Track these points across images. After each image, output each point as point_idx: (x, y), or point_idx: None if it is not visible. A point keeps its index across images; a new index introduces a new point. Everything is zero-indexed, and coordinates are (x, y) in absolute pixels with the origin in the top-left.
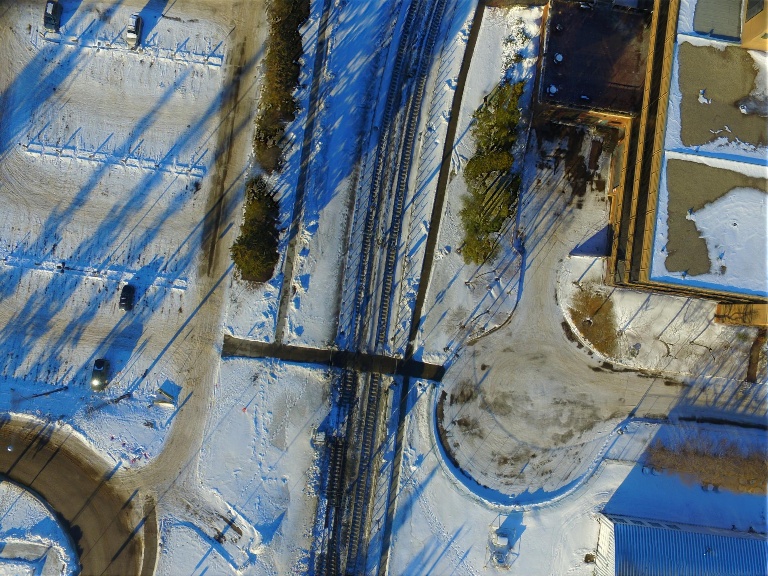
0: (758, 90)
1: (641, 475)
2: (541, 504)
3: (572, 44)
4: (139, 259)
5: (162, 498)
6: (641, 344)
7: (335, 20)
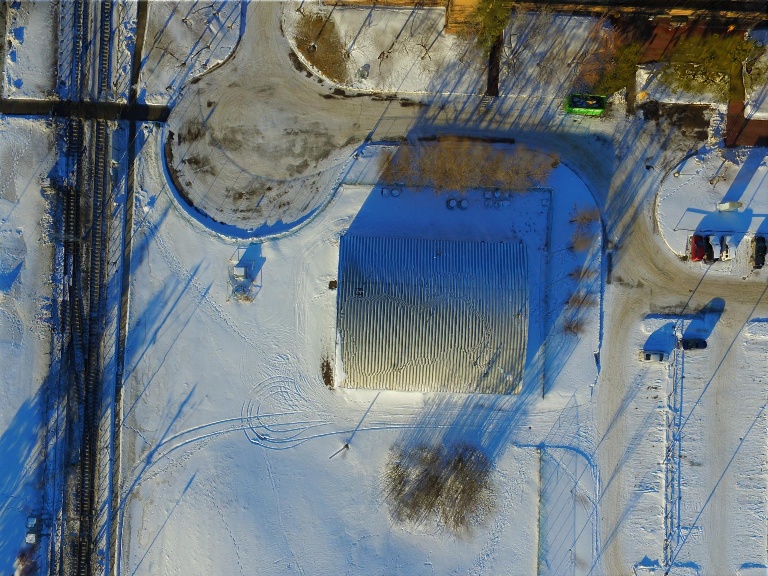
0: None
1: (381, 198)
2: (280, 235)
3: None
4: None
5: None
6: (370, 65)
7: None
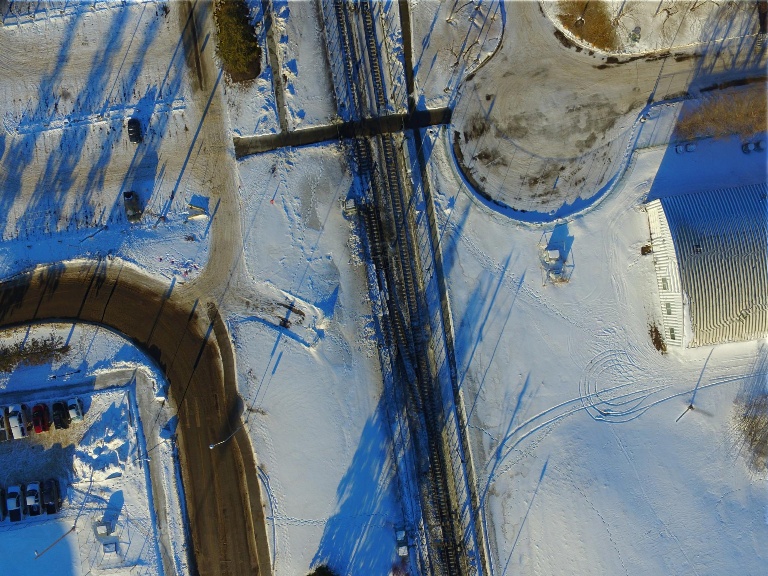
0: None
1: (676, 156)
2: (583, 212)
3: None
4: (134, 94)
5: (222, 301)
6: (640, 27)
7: None
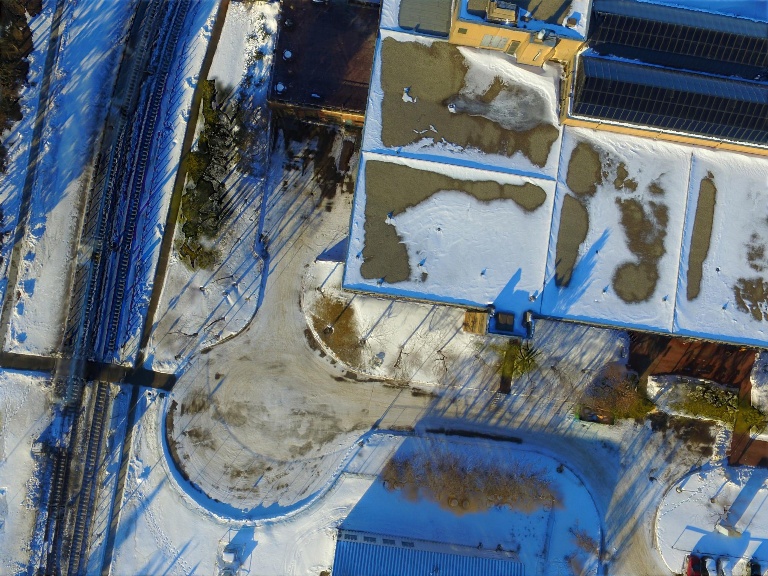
0: (468, 88)
1: (382, 490)
2: (275, 519)
3: (305, 40)
4: None
5: None
6: (385, 353)
7: (69, 15)
